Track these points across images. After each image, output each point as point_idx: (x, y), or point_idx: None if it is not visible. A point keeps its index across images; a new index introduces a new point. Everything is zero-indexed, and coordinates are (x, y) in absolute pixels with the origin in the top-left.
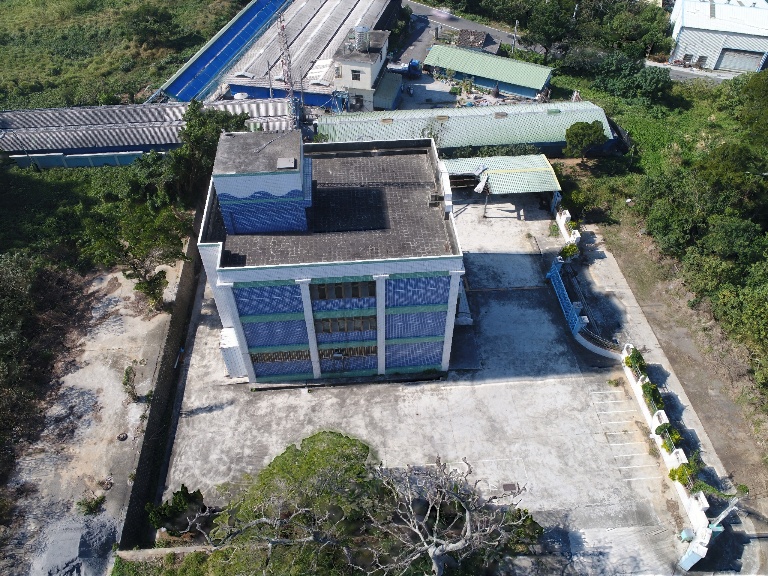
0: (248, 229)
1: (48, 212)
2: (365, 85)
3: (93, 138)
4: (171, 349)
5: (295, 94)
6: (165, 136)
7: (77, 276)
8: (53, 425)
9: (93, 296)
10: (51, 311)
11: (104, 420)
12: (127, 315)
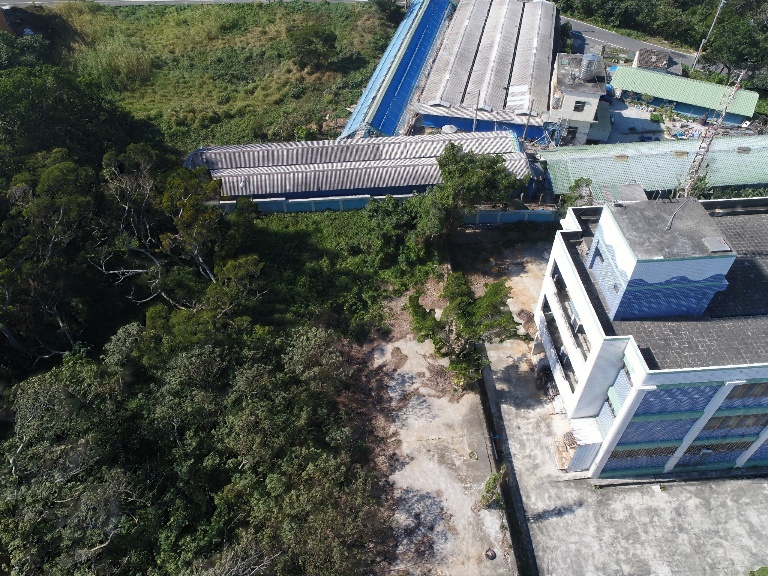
0: (636, 314)
1: (295, 269)
2: (587, 117)
3: (315, 181)
4: (489, 436)
5: (498, 125)
6: (393, 178)
7: (356, 347)
8: (406, 539)
9: (382, 371)
10: (347, 392)
11: (460, 532)
12: (430, 396)
